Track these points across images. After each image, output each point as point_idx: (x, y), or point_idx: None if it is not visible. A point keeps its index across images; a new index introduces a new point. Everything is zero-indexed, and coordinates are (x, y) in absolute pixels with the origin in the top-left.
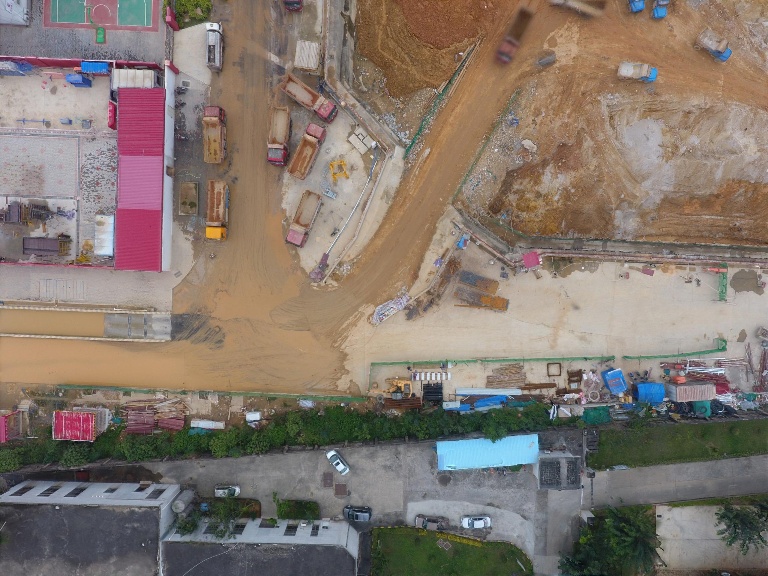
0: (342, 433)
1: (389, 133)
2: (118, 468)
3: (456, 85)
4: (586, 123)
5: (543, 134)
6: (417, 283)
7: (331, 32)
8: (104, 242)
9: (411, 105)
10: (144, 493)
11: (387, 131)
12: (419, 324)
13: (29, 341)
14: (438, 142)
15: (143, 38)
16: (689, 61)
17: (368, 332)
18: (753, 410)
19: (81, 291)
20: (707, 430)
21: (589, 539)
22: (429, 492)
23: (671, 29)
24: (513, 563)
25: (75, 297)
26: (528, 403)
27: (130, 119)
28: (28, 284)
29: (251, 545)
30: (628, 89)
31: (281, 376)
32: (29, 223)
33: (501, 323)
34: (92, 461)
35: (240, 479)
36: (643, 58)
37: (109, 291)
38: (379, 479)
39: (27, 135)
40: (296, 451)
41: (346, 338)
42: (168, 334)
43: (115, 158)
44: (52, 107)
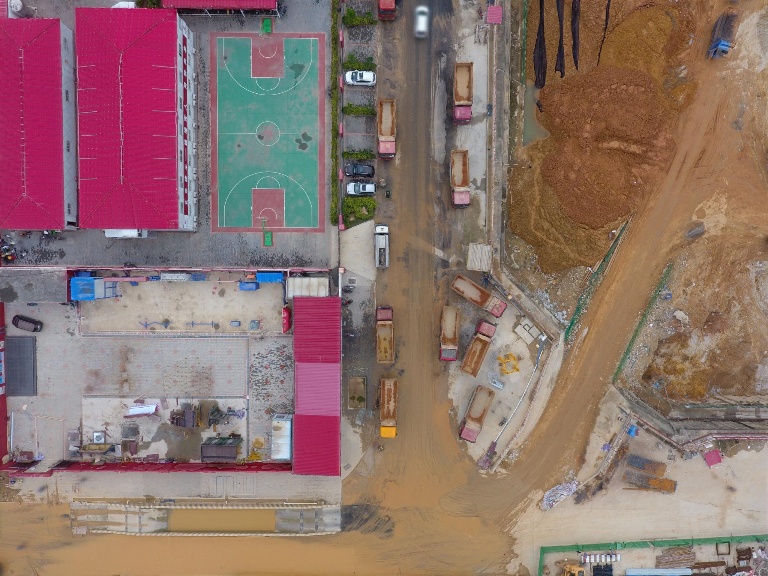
0: None
1: (549, 316)
2: None
3: (611, 263)
4: (736, 291)
5: (694, 304)
6: (585, 468)
7: (495, 226)
8: (281, 446)
9: (565, 283)
10: None
11: (547, 315)
12: (587, 507)
13: (201, 539)
14: (595, 321)
15: (310, 239)
16: None
17: (537, 517)
18: None
19: (251, 486)
20: None
21: None
22: None
23: None
24: None
25: (245, 492)
26: None
27: (306, 327)
28: (198, 482)
29: None
30: None
31: (451, 562)
32: (200, 424)
33: (669, 504)
34: None
35: None
36: None
37: (279, 486)
38: None
39: (196, 337)
40: None
41: (515, 524)
42: (338, 525)
43: (283, 356)
44: (220, 309)
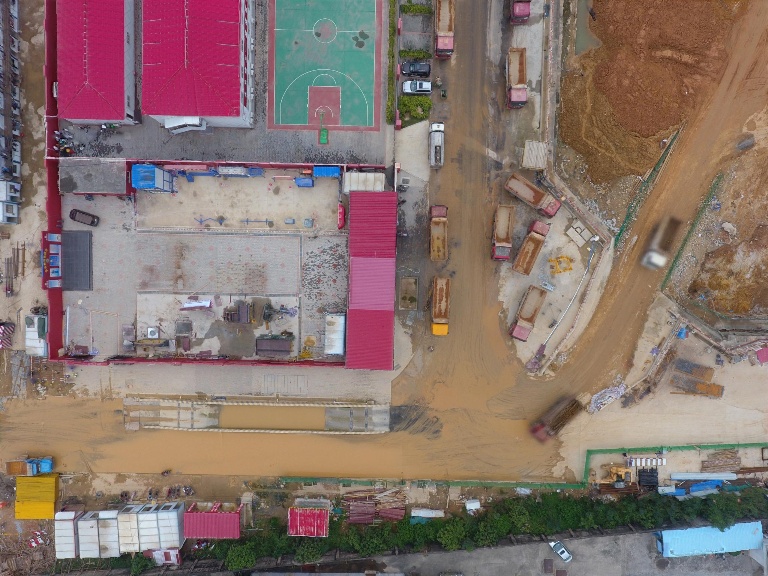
0: (565, 521)
1: None
2: None
3: (661, 172)
4: None
5: (742, 216)
6: (633, 372)
7: (549, 127)
8: (334, 341)
9: (615, 192)
10: None
11: None
12: (634, 411)
13: (252, 435)
14: (645, 229)
15: (365, 138)
16: None
17: (584, 420)
18: None
19: (302, 385)
20: None
21: None
22: (647, 575)
23: None
24: None
25: (296, 391)
26: (743, 487)
27: (362, 222)
28: (250, 379)
29: None
30: None
31: (497, 464)
32: (253, 321)
33: (716, 409)
34: (323, 554)
35: (463, 567)
36: None
37: (329, 385)
38: (598, 564)
39: (250, 235)
40: (526, 542)
41: (562, 426)
42: (387, 425)
43: (336, 255)
44: (275, 207)
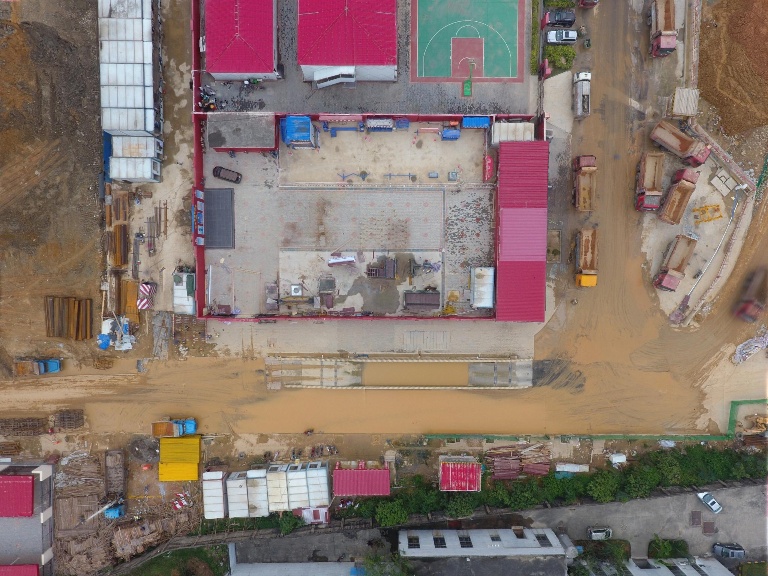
0: (714, 472)
1: None
2: None
3: None
4: None
5: None
6: None
7: None
8: (484, 294)
9: (750, 143)
10: (532, 540)
11: None
12: None
13: (396, 393)
14: None
15: (508, 89)
16: None
17: (728, 371)
18: None
19: (444, 341)
20: None
21: None
22: None
23: None
24: None
25: (438, 347)
26: None
27: (512, 172)
28: (392, 336)
29: None
30: None
31: (641, 417)
32: (396, 277)
33: None
34: (473, 510)
35: (610, 521)
36: None
37: (472, 340)
38: (746, 516)
39: (392, 190)
40: (679, 493)
41: (707, 378)
42: (530, 380)
43: (480, 209)
44: (418, 161)
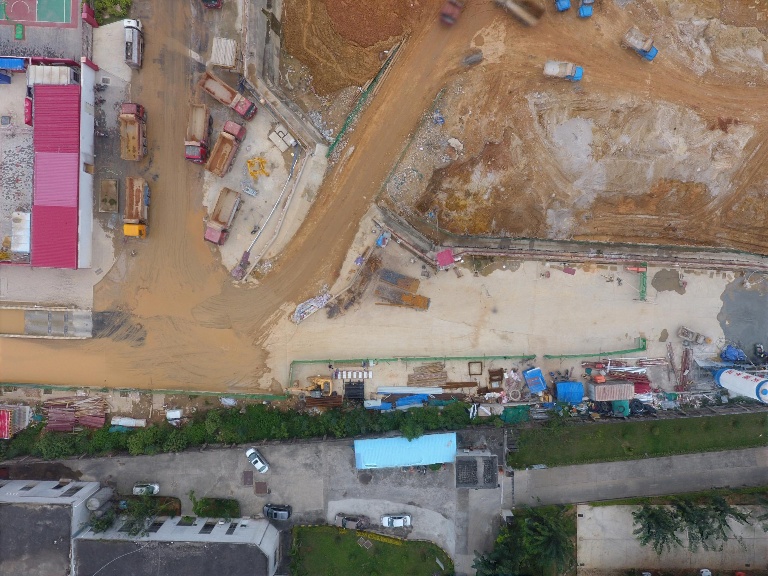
0: (261, 431)
1: (312, 131)
2: (37, 465)
3: (381, 83)
4: (513, 122)
5: (470, 133)
6: (338, 281)
7: (251, 29)
8: (21, 239)
9: (336, 103)
10: (60, 491)
11: (310, 129)
12: (340, 322)
13: None
14: (362, 140)
15: (62, 35)
16: (616, 60)
17: (289, 330)
18: (673, 410)
19: (2, 288)
20: (628, 429)
21: (506, 538)
22: (350, 491)
23: (598, 28)
24: (434, 562)
25: None
26: (449, 402)
27: (46, 116)
28: None
29: (164, 543)
30: (555, 88)
31: (203, 374)
32: None
33: (422, 322)
34: (9, 458)
35: (160, 477)
36: (570, 57)
37: (30, 288)
38: (299, 477)
39: None
40: (213, 449)
41: (267, 336)
42: (89, 331)
43: None
44: None
